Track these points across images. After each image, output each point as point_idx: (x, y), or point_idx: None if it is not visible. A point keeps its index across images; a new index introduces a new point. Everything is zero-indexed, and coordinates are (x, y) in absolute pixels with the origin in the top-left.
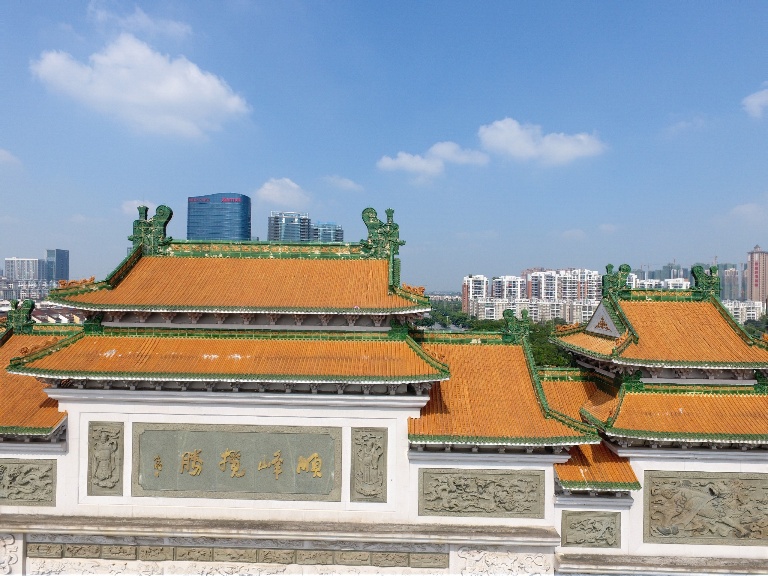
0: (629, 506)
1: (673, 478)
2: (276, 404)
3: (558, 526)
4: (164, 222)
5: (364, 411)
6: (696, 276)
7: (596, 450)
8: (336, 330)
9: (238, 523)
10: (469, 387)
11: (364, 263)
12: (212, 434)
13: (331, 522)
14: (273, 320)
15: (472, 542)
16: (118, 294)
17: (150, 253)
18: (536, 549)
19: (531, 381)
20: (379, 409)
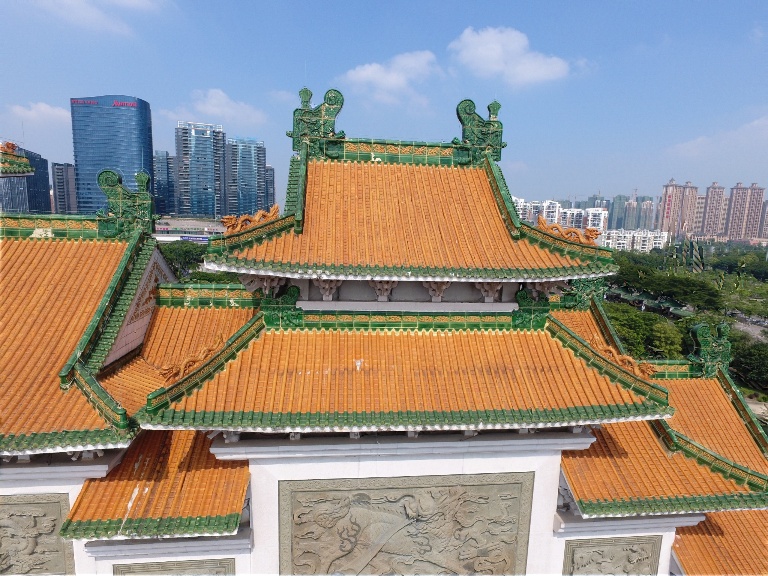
0: None
1: (337, 491)
2: None
3: None
4: None
5: None
6: (462, 119)
7: (199, 443)
8: None
9: None
10: None
11: None
12: None
13: None
14: None
15: None
16: None
17: None
18: None
19: None
20: None
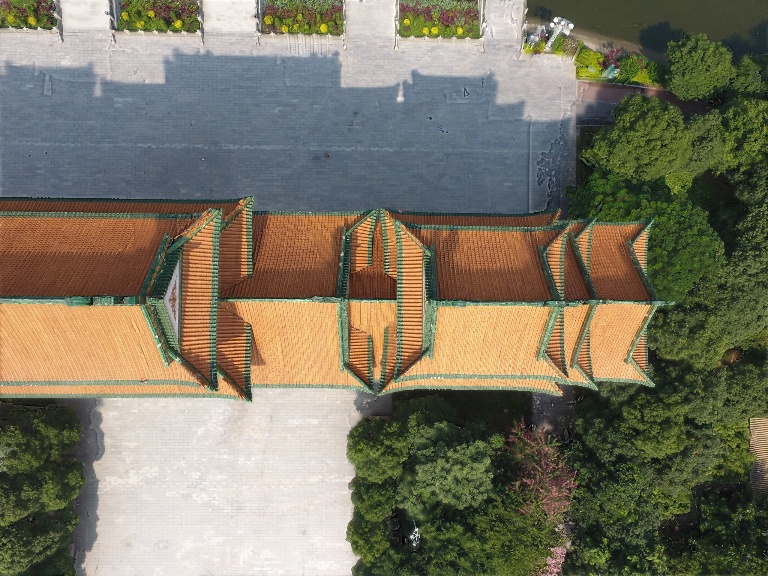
0: None
1: None
2: None
3: None
4: None
5: None
6: None
7: None
8: None
9: None
10: (282, 342)
11: (117, 310)
12: None
13: None
14: None
15: None
16: None
17: None
18: None
19: (338, 338)
20: None
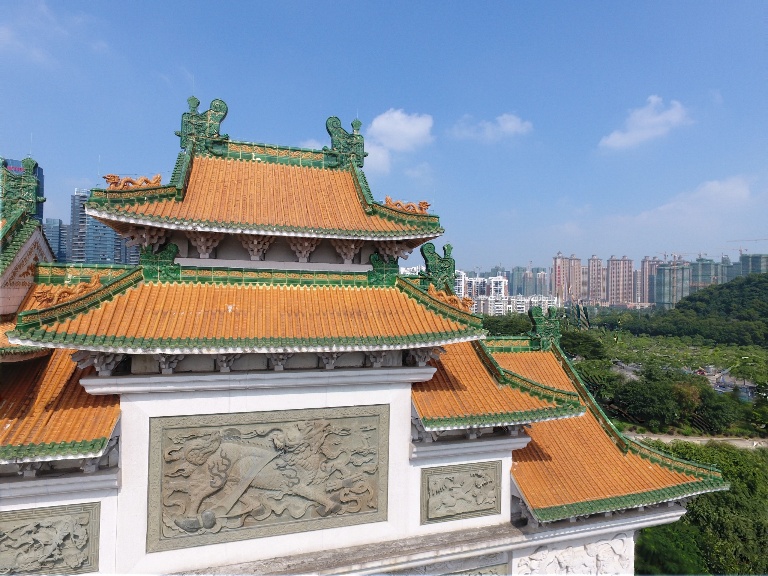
0: (117, 488)
1: (208, 427)
2: None
3: None
4: None
5: None
6: (330, 131)
7: (70, 389)
8: None
9: None
10: None
11: None
12: None
13: None
14: None
15: None
16: None
17: None
18: None
19: None
20: None
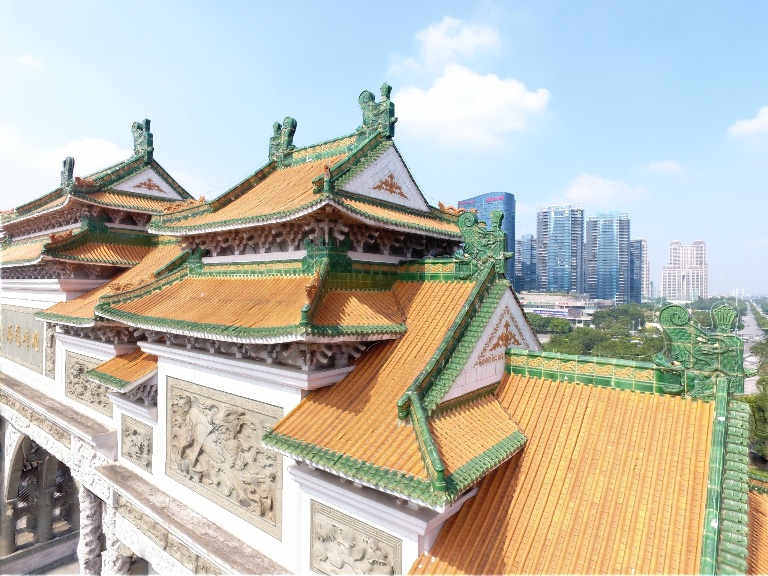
0: (157, 421)
1: (188, 392)
2: (24, 289)
3: (119, 431)
4: (68, 169)
5: (49, 295)
6: None
7: None
8: (65, 229)
9: (13, 381)
10: None
11: None
12: (14, 313)
13: (38, 391)
14: (49, 226)
15: (62, 425)
16: None
17: (65, 193)
18: (105, 451)
19: None
20: (53, 293)
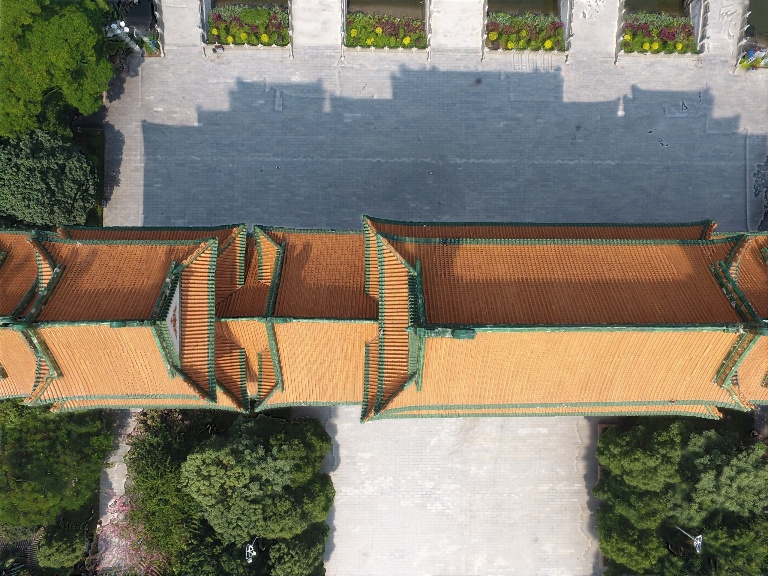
0: None
1: None
2: None
3: None
4: None
5: None
6: None
7: None
8: None
9: None
10: None
11: (709, 335)
12: None
13: None
14: None
15: None
16: (430, 389)
17: None
18: None
19: None
20: None
